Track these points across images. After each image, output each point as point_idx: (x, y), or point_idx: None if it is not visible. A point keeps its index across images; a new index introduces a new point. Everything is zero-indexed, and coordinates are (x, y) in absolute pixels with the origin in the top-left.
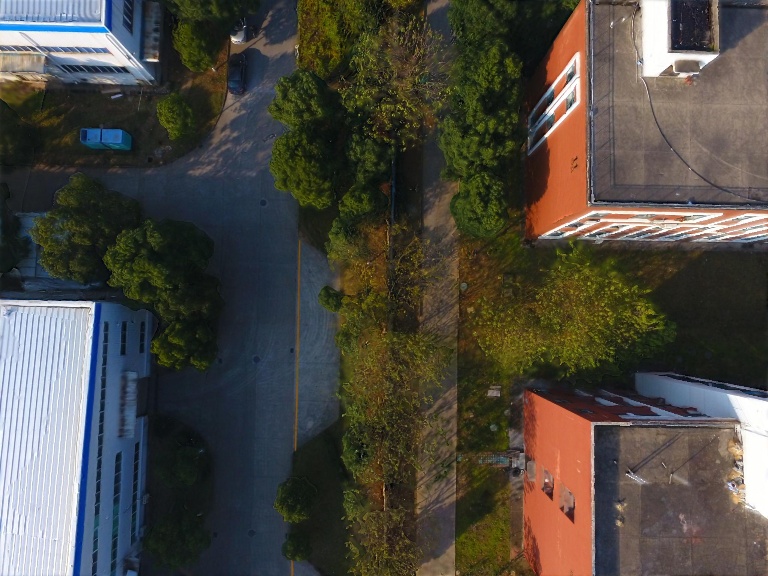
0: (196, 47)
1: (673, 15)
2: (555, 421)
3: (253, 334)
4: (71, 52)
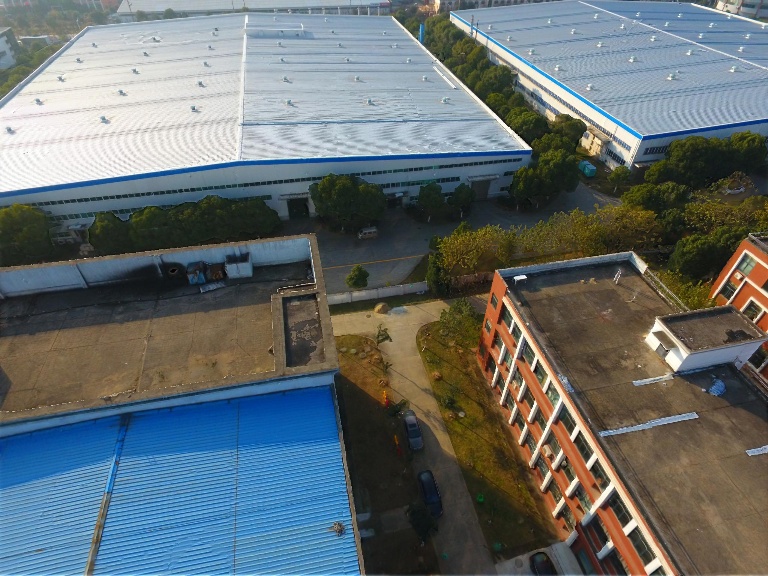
0: (658, 168)
1: None
2: None
3: (532, 224)
4: (619, 144)
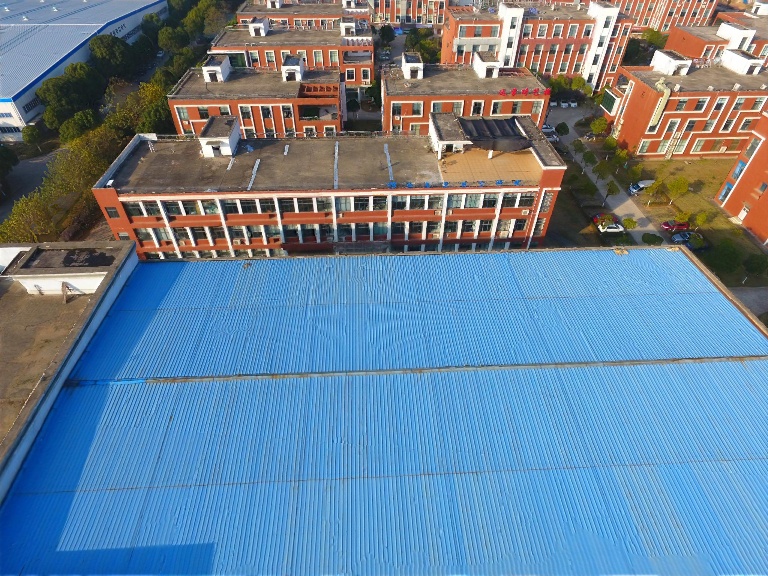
0: (51, 114)
1: None
2: None
3: None
4: None
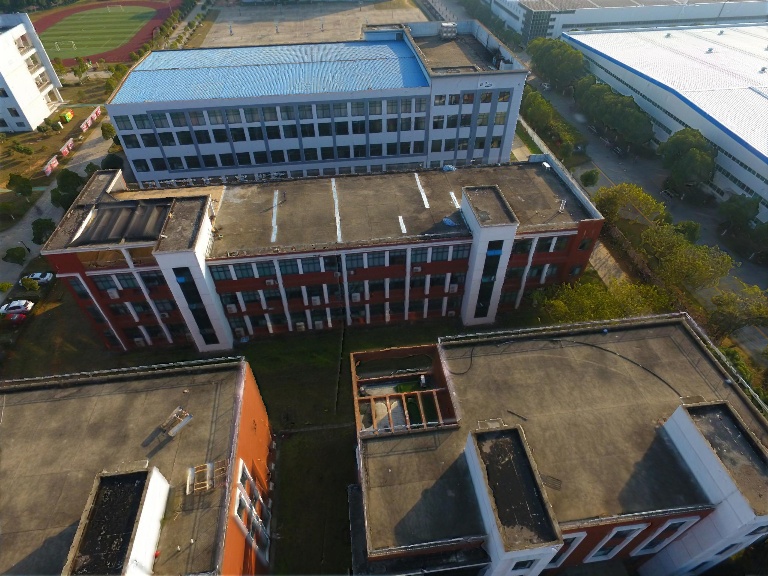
0: None
1: (744, 442)
2: None
3: None
4: None
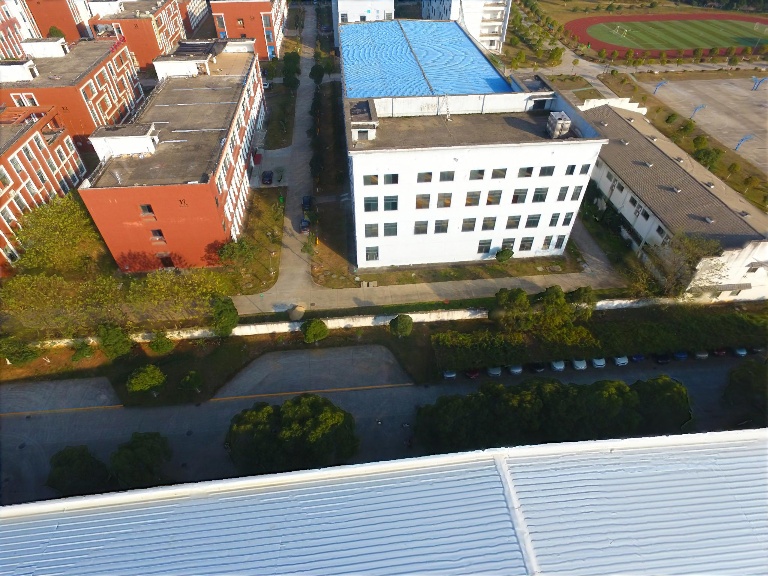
0: None
1: None
2: (109, 229)
3: None
4: None
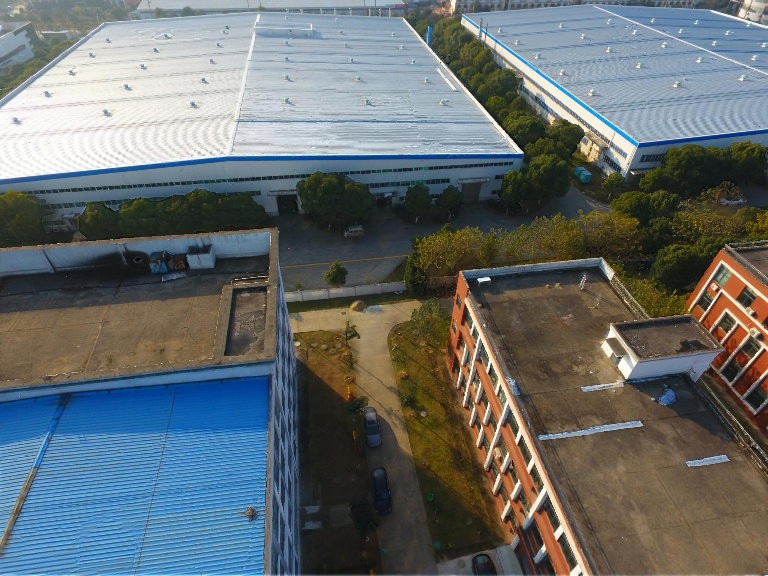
0: (653, 176)
1: None
2: None
3: None
4: (616, 151)
